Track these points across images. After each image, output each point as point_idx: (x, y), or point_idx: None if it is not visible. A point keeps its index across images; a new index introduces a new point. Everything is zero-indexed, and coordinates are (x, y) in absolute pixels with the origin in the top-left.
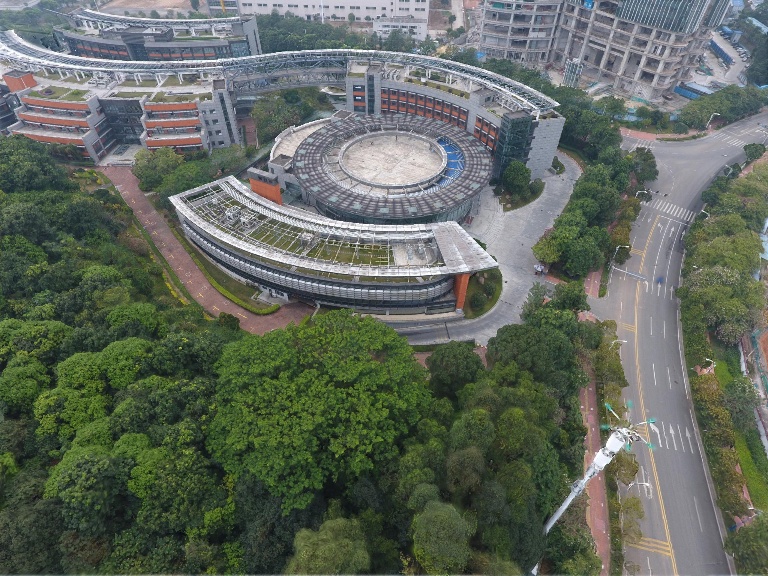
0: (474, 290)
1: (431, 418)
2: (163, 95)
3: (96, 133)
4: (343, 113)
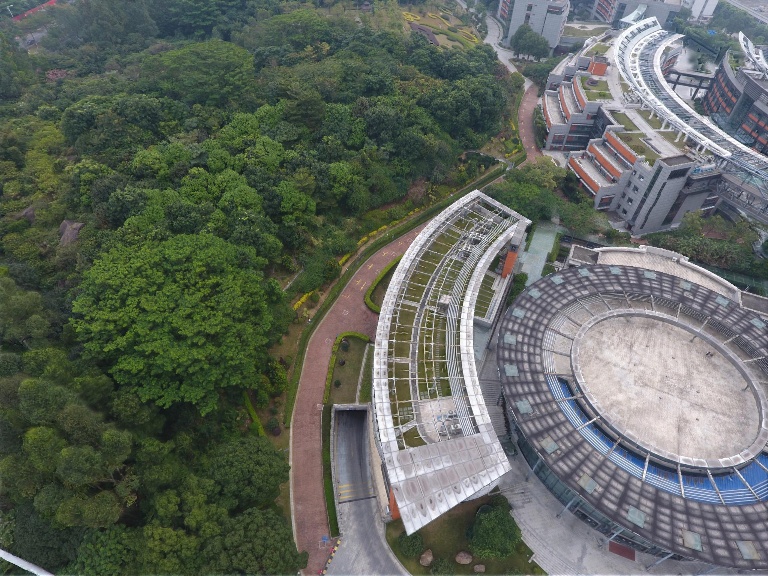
0: (443, 544)
1: (117, 393)
2: (639, 137)
3: (569, 129)
4: (763, 304)
